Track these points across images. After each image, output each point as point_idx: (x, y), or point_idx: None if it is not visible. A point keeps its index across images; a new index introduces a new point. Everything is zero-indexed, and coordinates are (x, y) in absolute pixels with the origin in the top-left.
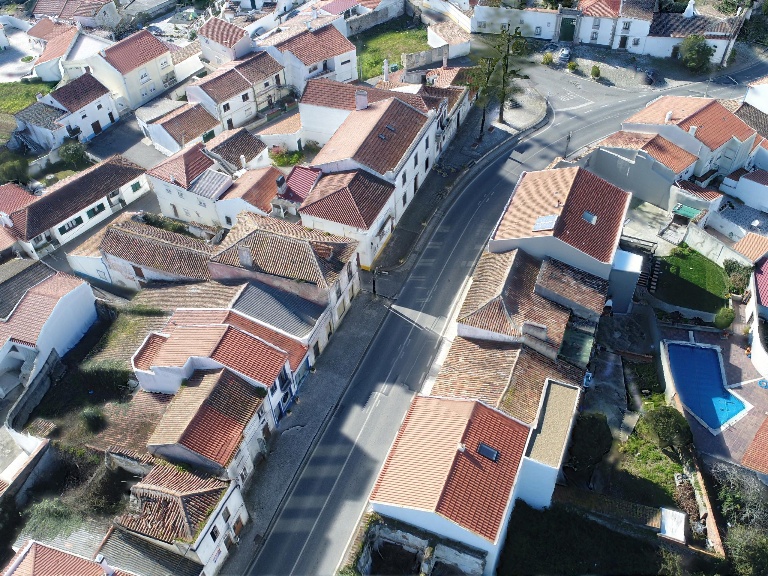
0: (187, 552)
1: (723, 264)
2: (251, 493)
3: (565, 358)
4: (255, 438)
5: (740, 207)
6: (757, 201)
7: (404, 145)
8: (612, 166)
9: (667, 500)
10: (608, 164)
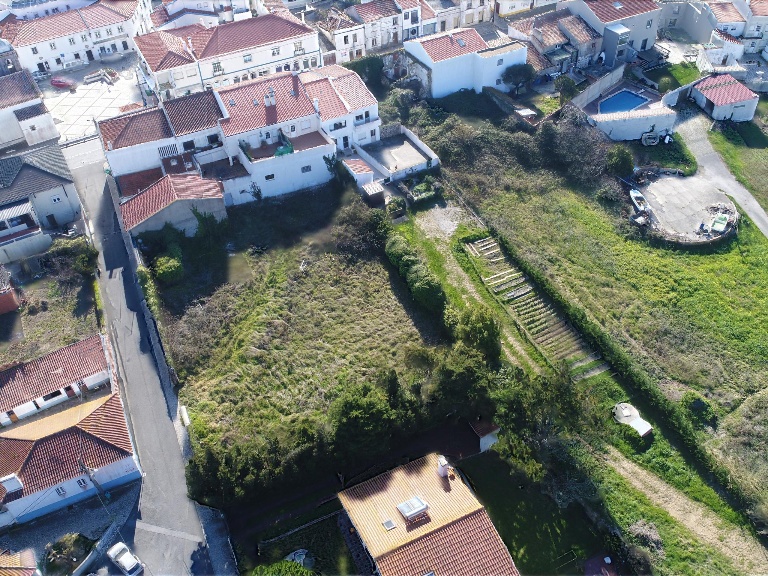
0: (333, 39)
1: (701, 72)
2: None
3: (547, 56)
4: (387, 31)
5: (765, 67)
6: None
7: None
8: (691, 16)
9: (540, 116)
10: (689, 14)
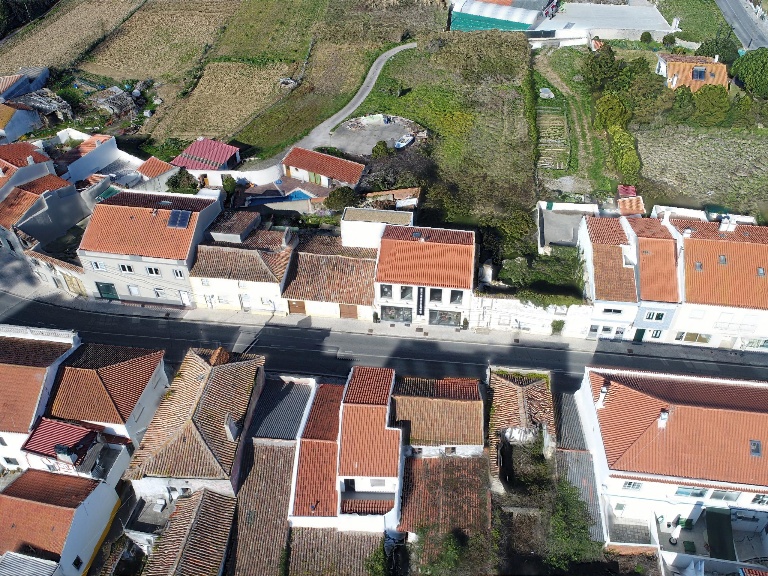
0: None
1: None
2: None
3: None
4: None
5: None
6: (87, 171)
7: (5, 343)
8: (37, 228)
9: None
10: (34, 230)
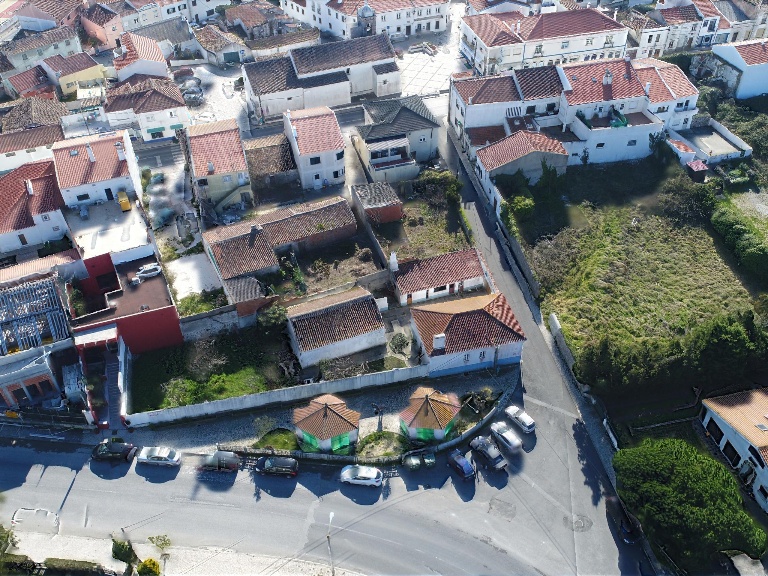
0: (638, 36)
1: None
2: (669, 54)
3: None
4: (685, 35)
5: None
6: None
7: None
8: None
9: None
10: None
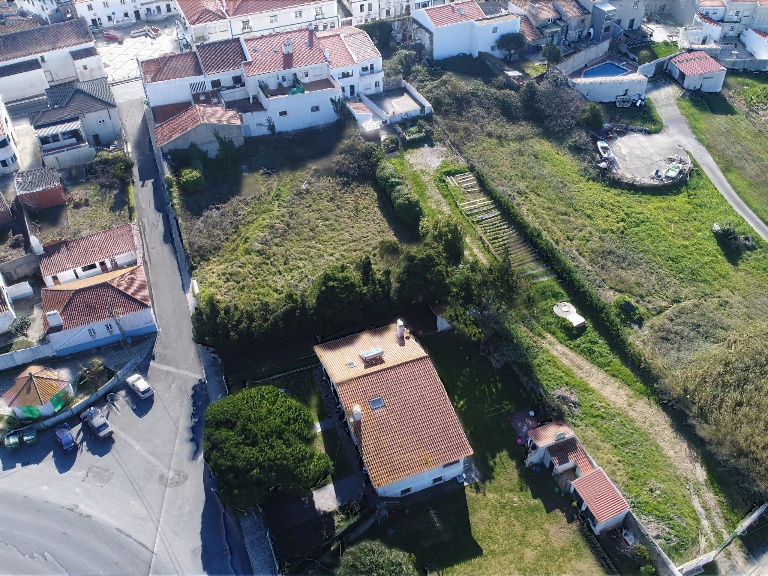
0: None
1: None
2: None
3: (540, 29)
4: (400, 3)
5: (742, 49)
6: (751, 46)
7: None
8: (678, 2)
9: None
10: (677, 0)
